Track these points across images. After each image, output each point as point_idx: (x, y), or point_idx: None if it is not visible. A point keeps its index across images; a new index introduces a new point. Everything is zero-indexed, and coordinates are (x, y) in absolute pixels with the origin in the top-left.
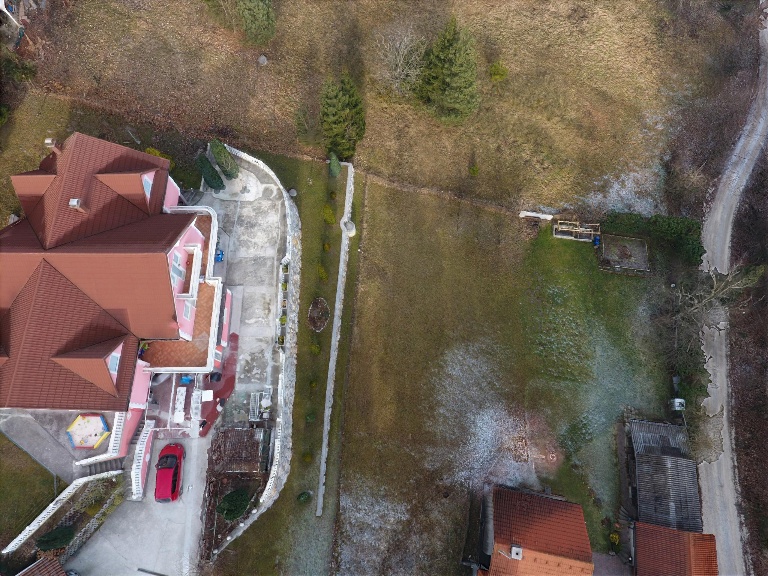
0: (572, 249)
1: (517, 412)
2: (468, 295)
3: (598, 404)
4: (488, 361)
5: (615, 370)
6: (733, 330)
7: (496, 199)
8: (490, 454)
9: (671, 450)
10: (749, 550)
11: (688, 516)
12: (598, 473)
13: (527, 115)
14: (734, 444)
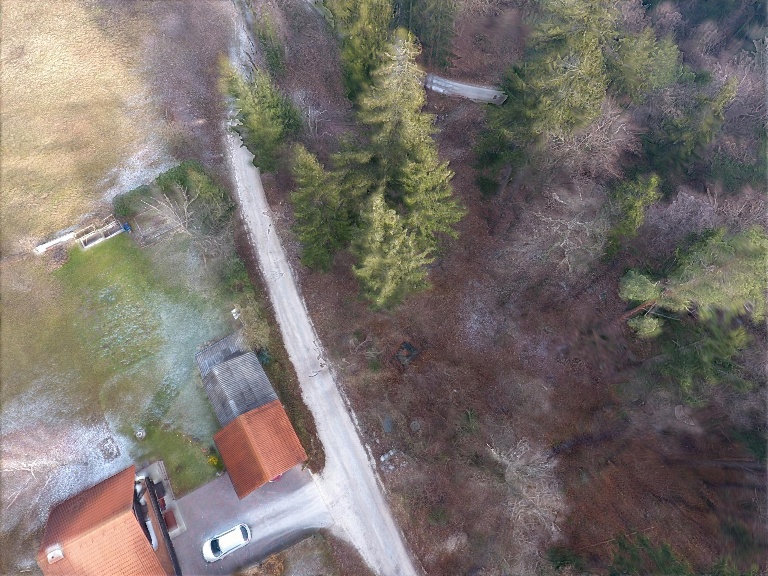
0: (110, 247)
1: (95, 421)
2: (7, 354)
3: (176, 360)
4: (48, 397)
5: (184, 322)
6: (278, 222)
7: (5, 253)
8: (77, 476)
9: (232, 356)
10: (340, 384)
11: (256, 400)
12: (192, 417)
13: (3, 163)
14: (307, 310)
